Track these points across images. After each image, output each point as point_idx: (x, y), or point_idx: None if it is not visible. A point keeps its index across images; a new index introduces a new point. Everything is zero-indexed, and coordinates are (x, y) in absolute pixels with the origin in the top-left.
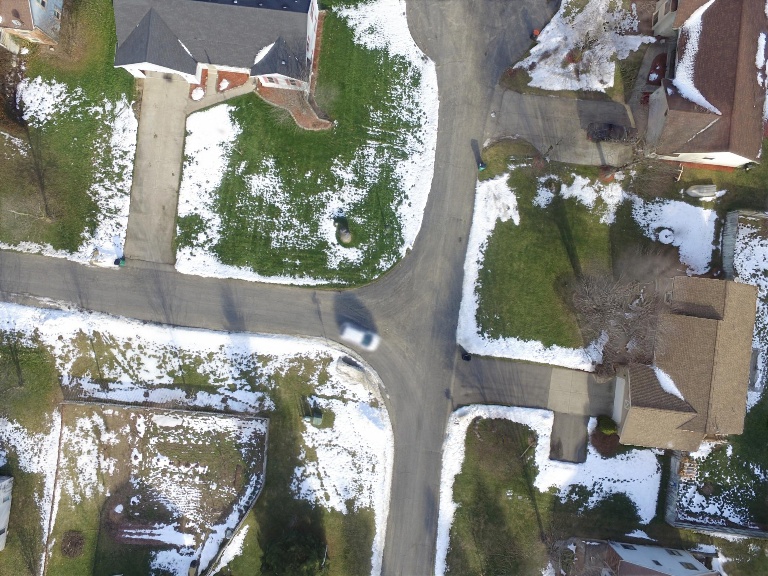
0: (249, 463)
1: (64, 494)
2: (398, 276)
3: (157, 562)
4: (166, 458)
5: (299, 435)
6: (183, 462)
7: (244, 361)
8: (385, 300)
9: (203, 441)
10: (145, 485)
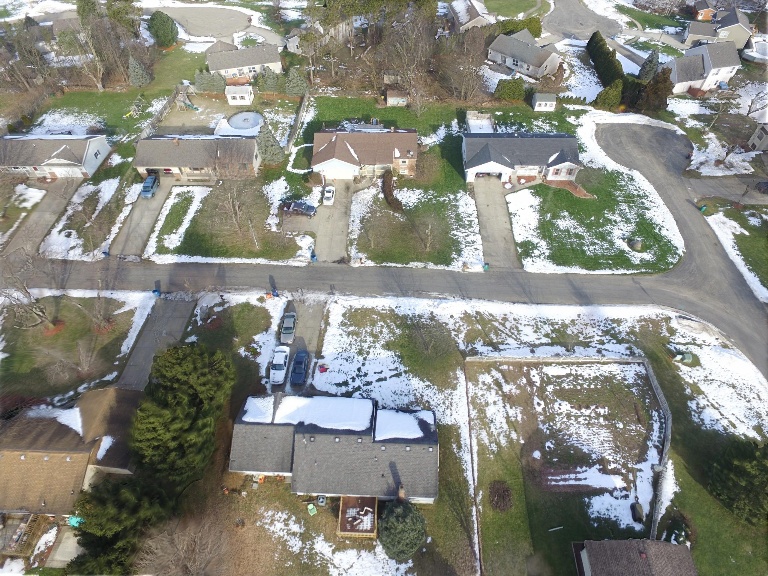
0: (644, 401)
1: (480, 444)
2: (687, 266)
3: (594, 509)
4: (566, 403)
5: (676, 374)
6: (583, 405)
7: (601, 324)
8: (687, 279)
9: (594, 385)
10: (554, 430)
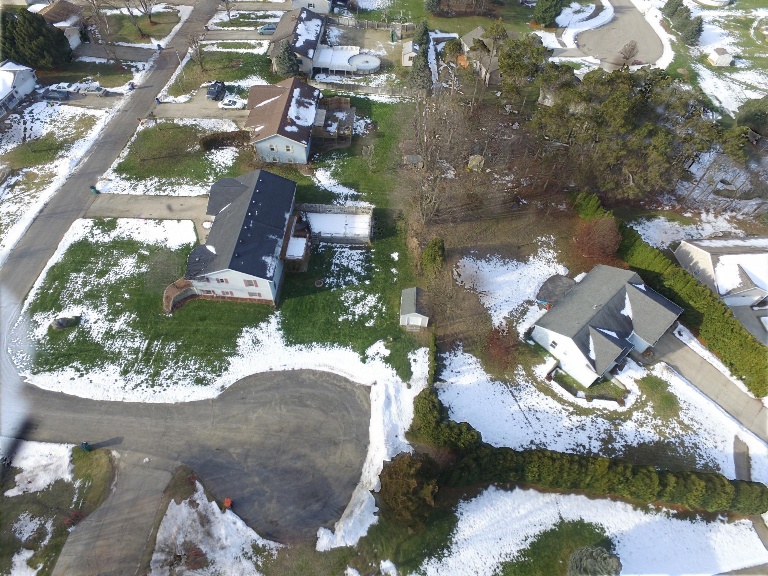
0: None
1: None
2: (2, 370)
3: None
4: None
5: None
6: None
7: None
8: None
9: None
10: None
